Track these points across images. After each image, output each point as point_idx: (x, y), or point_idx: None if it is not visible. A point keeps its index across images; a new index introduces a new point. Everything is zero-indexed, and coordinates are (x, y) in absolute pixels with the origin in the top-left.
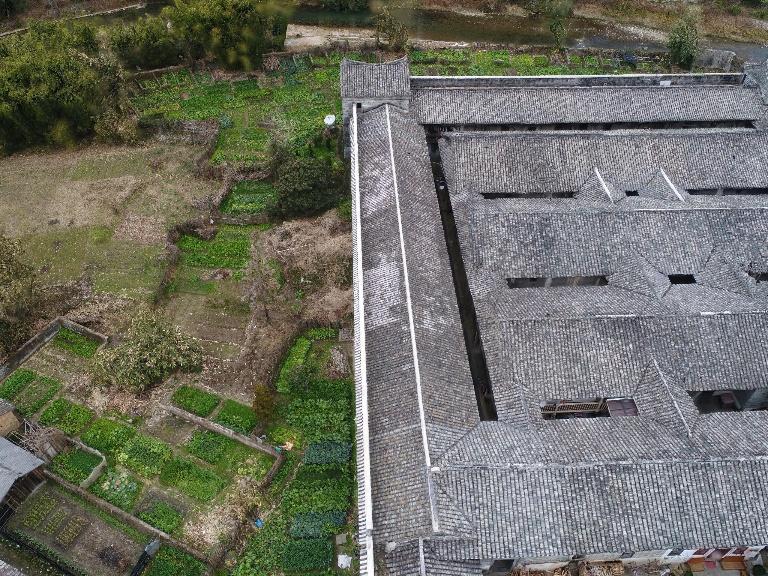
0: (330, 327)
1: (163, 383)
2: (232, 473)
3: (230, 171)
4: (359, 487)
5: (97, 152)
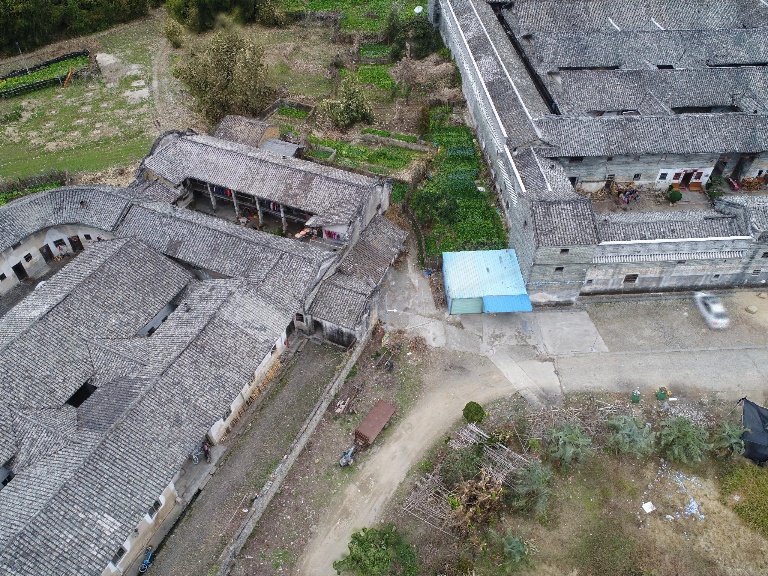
0: (448, 104)
1: (354, 128)
2: (408, 159)
3: (358, 36)
4: (493, 137)
5: (258, 31)
